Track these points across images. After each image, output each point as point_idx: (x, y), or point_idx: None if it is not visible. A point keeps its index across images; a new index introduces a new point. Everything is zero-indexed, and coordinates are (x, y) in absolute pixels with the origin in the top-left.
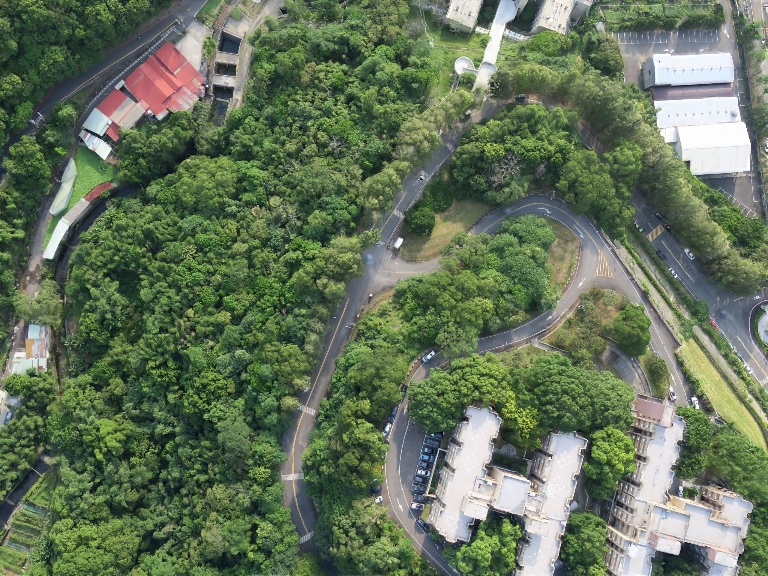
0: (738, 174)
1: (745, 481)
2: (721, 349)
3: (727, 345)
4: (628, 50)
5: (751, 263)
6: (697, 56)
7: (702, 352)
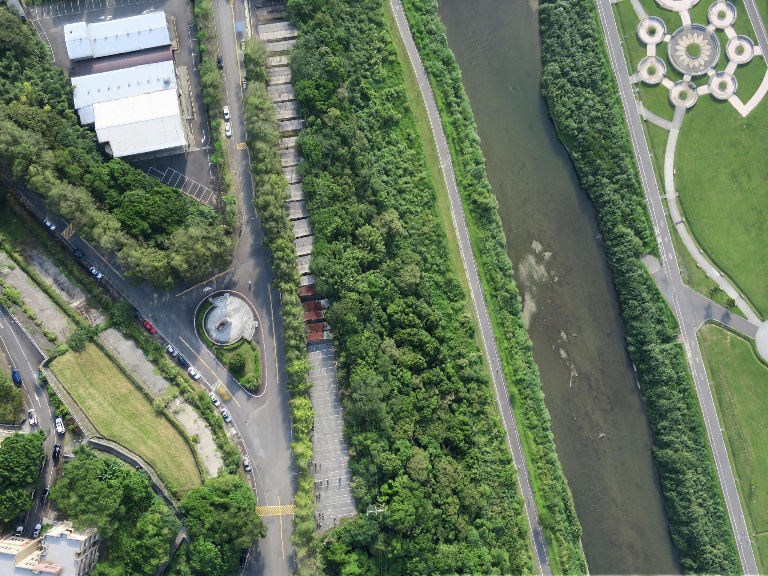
0: (190, 149)
1: (81, 515)
2: (148, 354)
3: (156, 349)
4: (56, 24)
5: (145, 253)
6: (122, 20)
7: (110, 361)
